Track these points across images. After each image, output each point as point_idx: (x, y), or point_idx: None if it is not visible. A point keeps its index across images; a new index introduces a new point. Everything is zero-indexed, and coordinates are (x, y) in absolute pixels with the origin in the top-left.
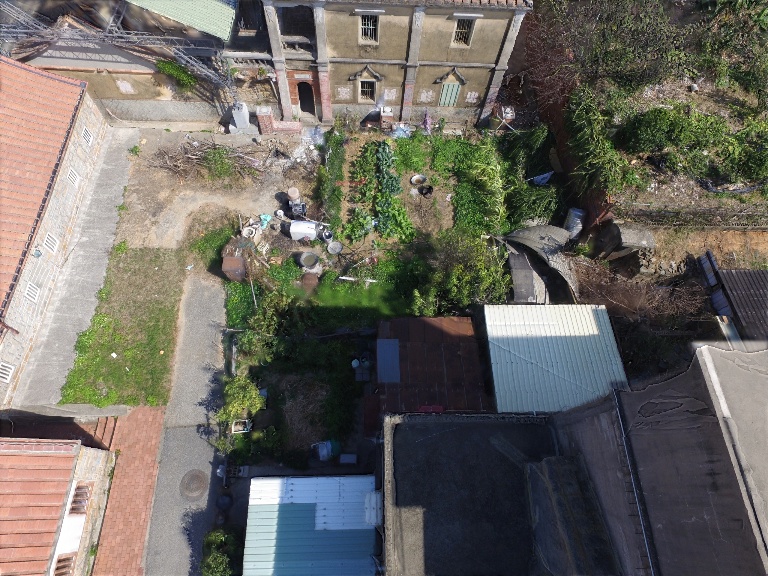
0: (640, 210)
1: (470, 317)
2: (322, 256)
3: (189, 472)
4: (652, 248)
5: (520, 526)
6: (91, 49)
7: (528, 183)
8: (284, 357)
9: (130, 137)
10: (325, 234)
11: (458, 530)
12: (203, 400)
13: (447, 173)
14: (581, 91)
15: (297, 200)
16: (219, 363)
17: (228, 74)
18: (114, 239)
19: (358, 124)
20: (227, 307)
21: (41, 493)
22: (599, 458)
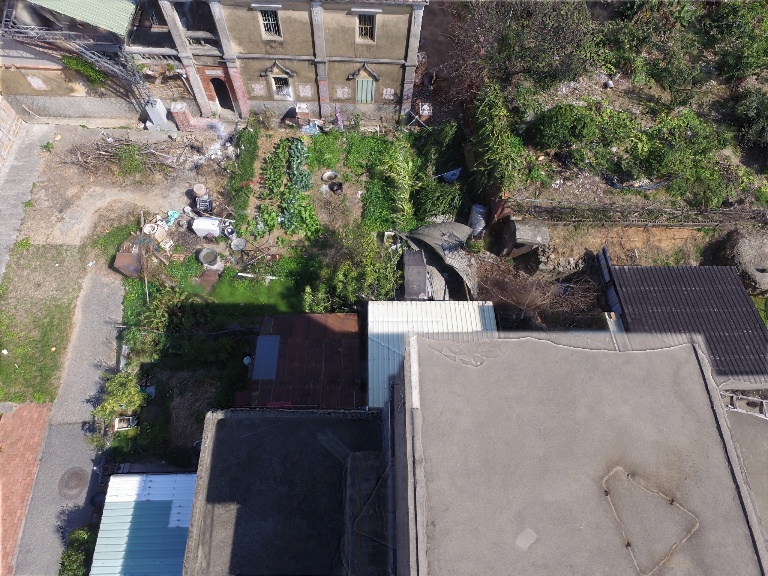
0: (534, 206)
1: (357, 313)
2: (225, 253)
3: (69, 469)
4: (551, 245)
5: (334, 522)
6: None
7: (438, 180)
8: (172, 354)
9: (44, 133)
10: (227, 230)
11: (270, 526)
12: (91, 397)
13: (360, 170)
14: (488, 87)
15: (204, 196)
16: (111, 360)
17: (134, 70)
18: (17, 235)
19: (279, 121)
20: (123, 304)
21: None
22: (389, 453)
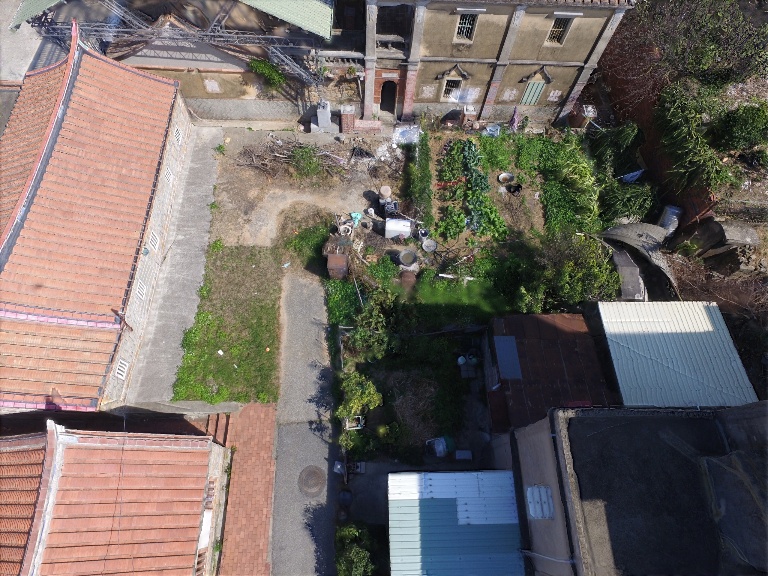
0: (744, 207)
1: (581, 314)
2: (417, 254)
3: (306, 468)
4: (752, 245)
5: (701, 519)
6: (186, 48)
7: (617, 181)
8: (394, 354)
9: (214, 136)
10: (421, 232)
11: (641, 523)
12: (313, 397)
13: (533, 171)
14: (673, 89)
15: (388, 198)
16: (325, 360)
17: (320, 73)
18: (209, 237)
19: None
20: (329, 305)
21: (183, 488)
22: None
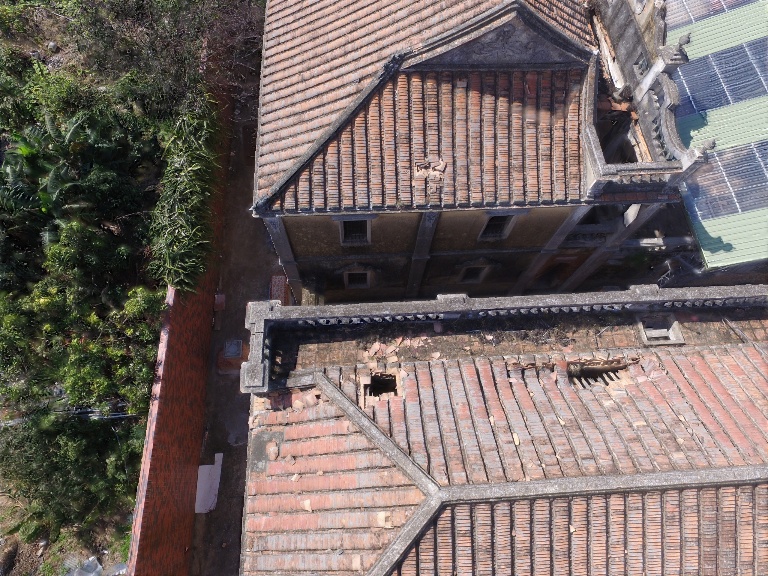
0: None
1: None
2: None
3: None
4: None
5: None
6: None
7: None
8: None
9: None
10: None
11: None
12: None
13: None
14: None
15: None
16: None
17: None
18: None
19: None
20: None
21: None
22: None
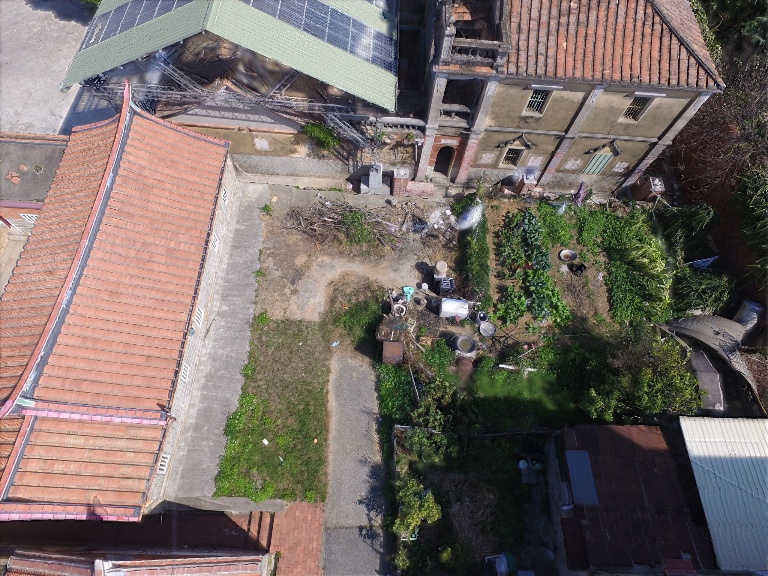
0: None
1: (659, 426)
2: (474, 338)
3: None
4: None
5: None
6: (240, 109)
7: (687, 265)
8: (452, 457)
9: (260, 194)
10: (480, 315)
11: None
12: (363, 498)
13: (596, 249)
14: (754, 173)
15: (443, 274)
16: (375, 455)
17: (378, 139)
18: (254, 309)
19: None
20: (380, 392)
21: None
22: None
